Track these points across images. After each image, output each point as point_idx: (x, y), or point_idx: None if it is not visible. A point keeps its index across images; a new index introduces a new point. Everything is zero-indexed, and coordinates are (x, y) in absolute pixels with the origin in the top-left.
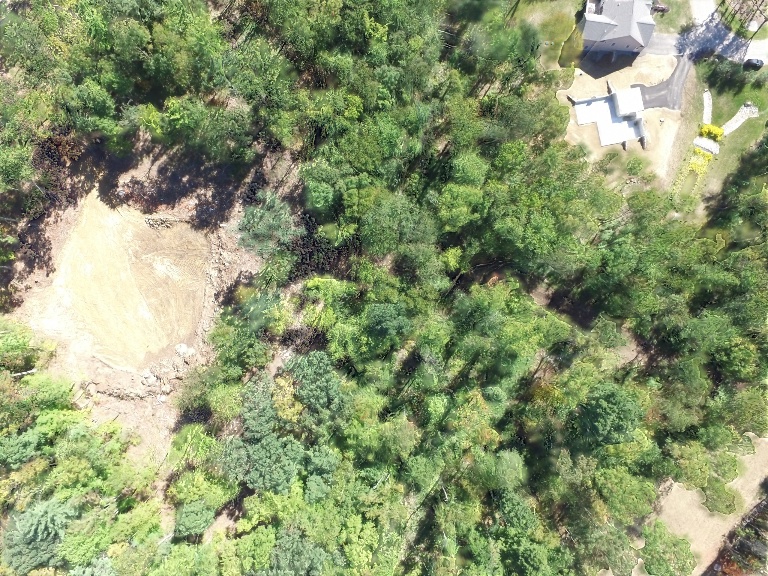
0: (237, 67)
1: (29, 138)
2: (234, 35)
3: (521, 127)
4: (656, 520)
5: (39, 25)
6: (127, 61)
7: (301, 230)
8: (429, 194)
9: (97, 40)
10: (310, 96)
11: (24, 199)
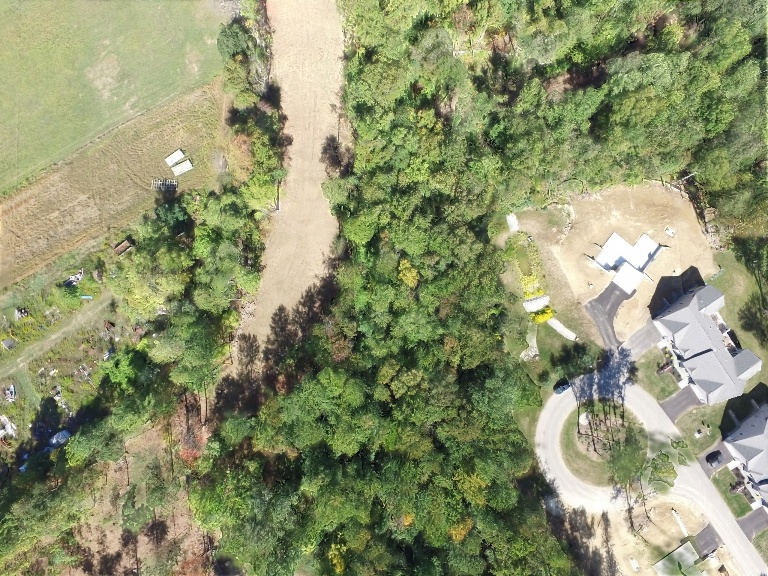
0: None
1: None
2: None
3: (738, 135)
4: (336, 1)
5: None
6: None
7: None
8: None
9: None
10: None
11: None
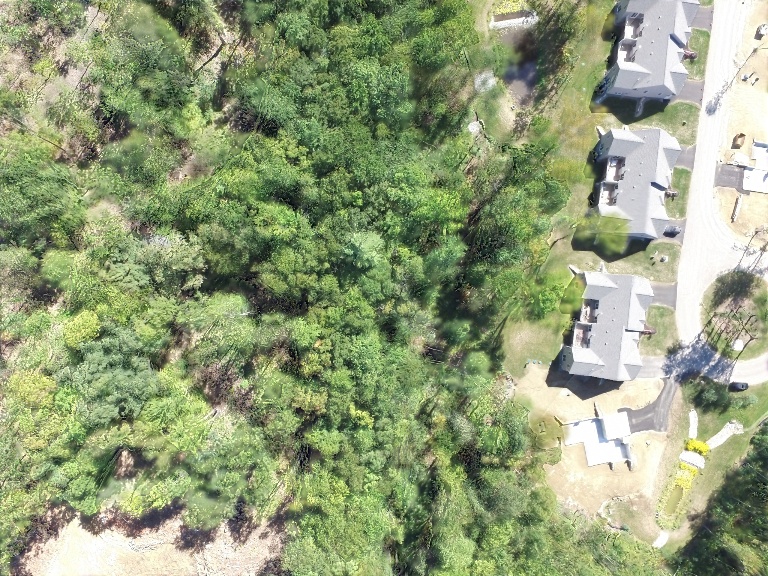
0: (221, 388)
1: (7, 477)
2: (218, 356)
3: (508, 514)
4: None
5: (15, 362)
6: (107, 449)
7: (288, 547)
8: (417, 508)
9: (75, 436)
10: (296, 414)
11: (3, 540)
